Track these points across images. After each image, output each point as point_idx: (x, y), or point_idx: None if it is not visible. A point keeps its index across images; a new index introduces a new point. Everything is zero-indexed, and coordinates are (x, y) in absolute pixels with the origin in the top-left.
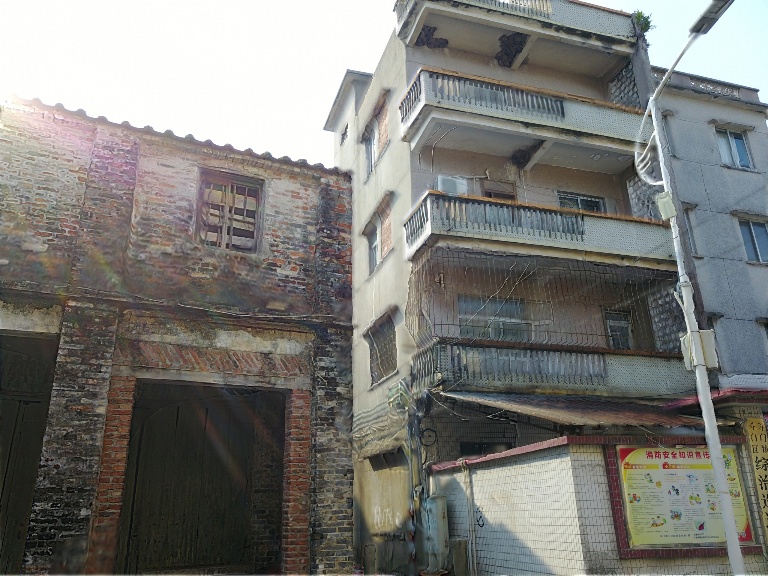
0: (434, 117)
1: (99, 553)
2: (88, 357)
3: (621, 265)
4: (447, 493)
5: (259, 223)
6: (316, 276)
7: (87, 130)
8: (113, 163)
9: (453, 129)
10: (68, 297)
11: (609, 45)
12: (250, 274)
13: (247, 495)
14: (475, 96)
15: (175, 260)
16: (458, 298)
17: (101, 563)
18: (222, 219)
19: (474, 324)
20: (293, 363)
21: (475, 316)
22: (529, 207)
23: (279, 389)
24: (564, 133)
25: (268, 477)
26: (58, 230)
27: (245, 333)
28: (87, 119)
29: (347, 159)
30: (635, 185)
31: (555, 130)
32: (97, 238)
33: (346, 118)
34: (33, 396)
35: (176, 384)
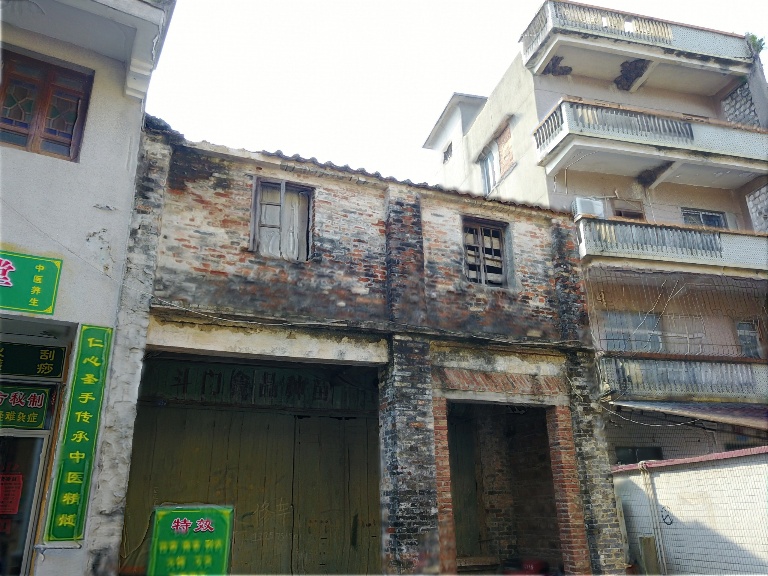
0: (576, 144)
1: (444, 544)
2: (415, 382)
3: (756, 279)
4: (622, 494)
5: (505, 261)
6: (560, 306)
7: (380, 188)
8: (405, 216)
9: (590, 154)
10: (394, 332)
11: (726, 67)
12: (511, 306)
13: (478, 496)
14: (612, 123)
15: (457, 297)
16: (620, 315)
17: (447, 552)
18: (478, 258)
19: (636, 338)
20: (553, 383)
21: (636, 331)
22: (671, 227)
23: (545, 405)
24: (693, 154)
25: (500, 480)
26: (373, 275)
27: (515, 358)
28: (382, 180)
29: (454, 177)
30: (755, 200)
31: (685, 152)
32: (405, 281)
33: (450, 137)
34: (305, 411)
35: (474, 403)
